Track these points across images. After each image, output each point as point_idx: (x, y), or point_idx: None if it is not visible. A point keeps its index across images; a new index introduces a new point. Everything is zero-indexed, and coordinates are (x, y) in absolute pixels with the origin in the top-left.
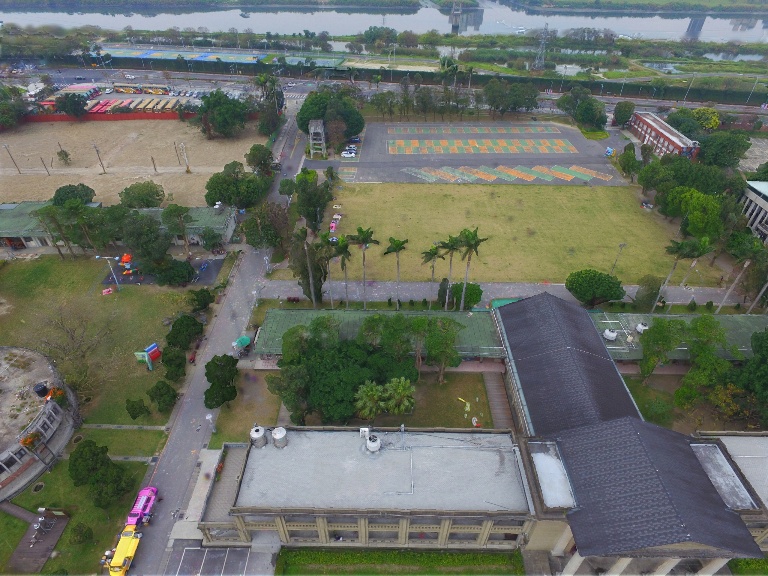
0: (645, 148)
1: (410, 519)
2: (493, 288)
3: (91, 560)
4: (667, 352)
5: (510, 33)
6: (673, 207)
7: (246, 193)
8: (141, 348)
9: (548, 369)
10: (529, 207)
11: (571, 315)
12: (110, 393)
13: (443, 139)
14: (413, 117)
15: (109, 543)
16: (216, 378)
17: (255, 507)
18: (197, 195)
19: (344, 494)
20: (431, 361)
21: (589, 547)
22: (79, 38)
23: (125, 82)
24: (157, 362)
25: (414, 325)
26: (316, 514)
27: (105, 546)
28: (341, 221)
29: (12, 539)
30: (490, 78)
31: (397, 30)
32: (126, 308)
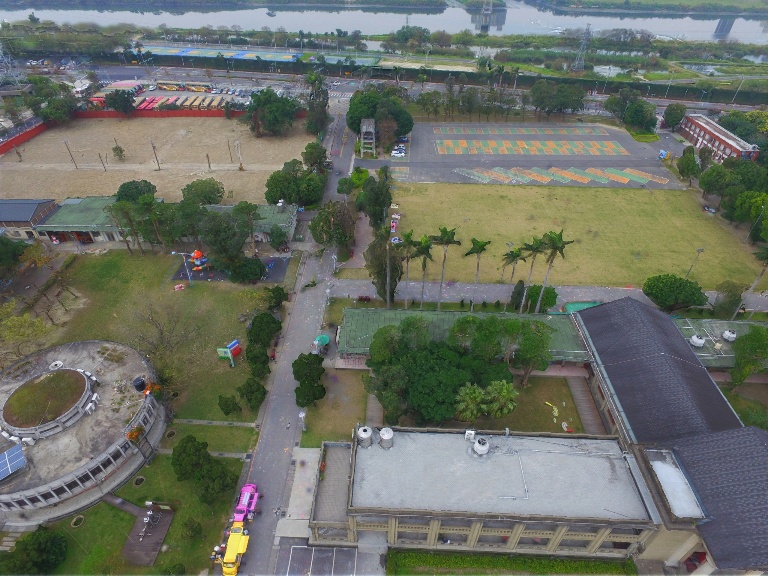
0: (704, 151)
1: (525, 524)
2: (564, 291)
3: (201, 555)
4: (764, 360)
5: (551, 33)
6: (741, 212)
7: (307, 191)
8: (220, 344)
9: (643, 375)
10: (588, 210)
11: (657, 320)
12: (196, 389)
13: (491, 140)
14: (458, 117)
15: (216, 539)
16: (304, 376)
17: (373, 508)
18: (253, 193)
19: (459, 497)
20: (519, 364)
21: (727, 559)
22: (127, 35)
23: (167, 79)
24: (238, 359)
25: (508, 328)
26: (433, 517)
27: (213, 542)
28: (401, 221)
29: (121, 532)
30: (532, 79)
31: (438, 30)
32: (200, 304)
